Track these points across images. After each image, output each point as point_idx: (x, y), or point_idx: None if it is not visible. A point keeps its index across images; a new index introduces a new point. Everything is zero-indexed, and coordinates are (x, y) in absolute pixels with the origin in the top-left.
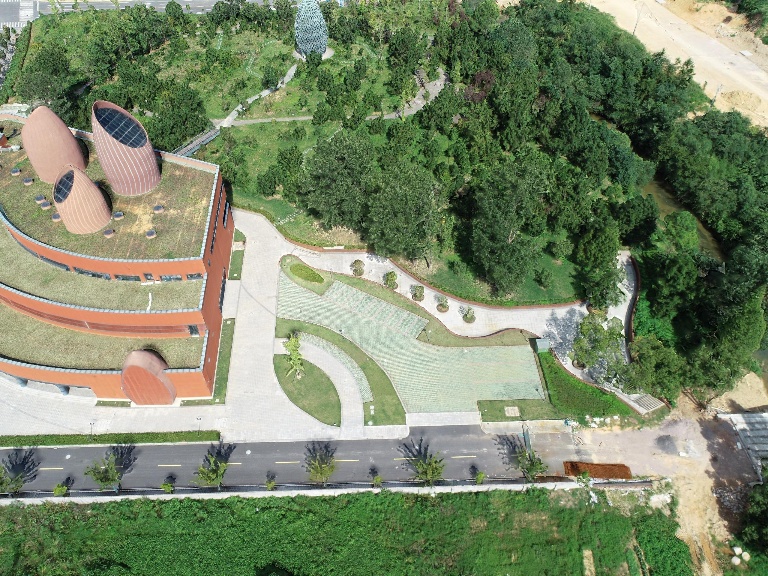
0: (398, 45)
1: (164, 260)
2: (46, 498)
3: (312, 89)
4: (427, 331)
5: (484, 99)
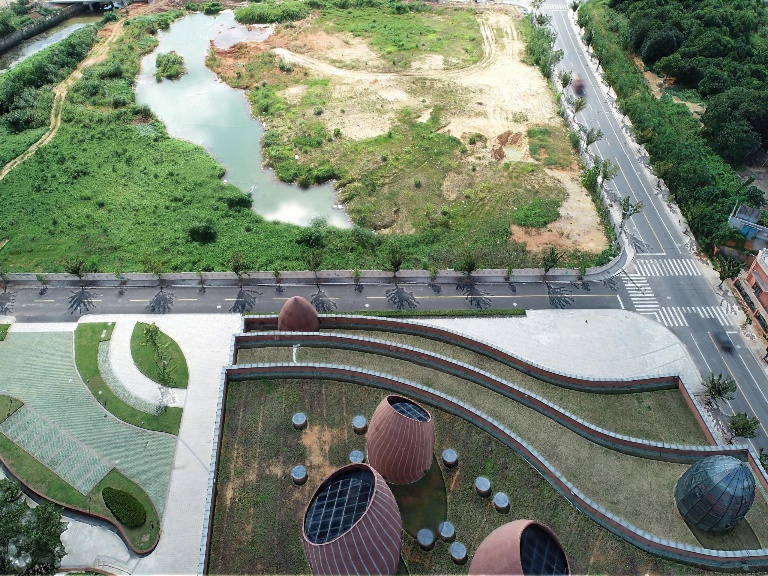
0: None
1: (269, 364)
2: (365, 270)
3: None
4: (6, 413)
5: None
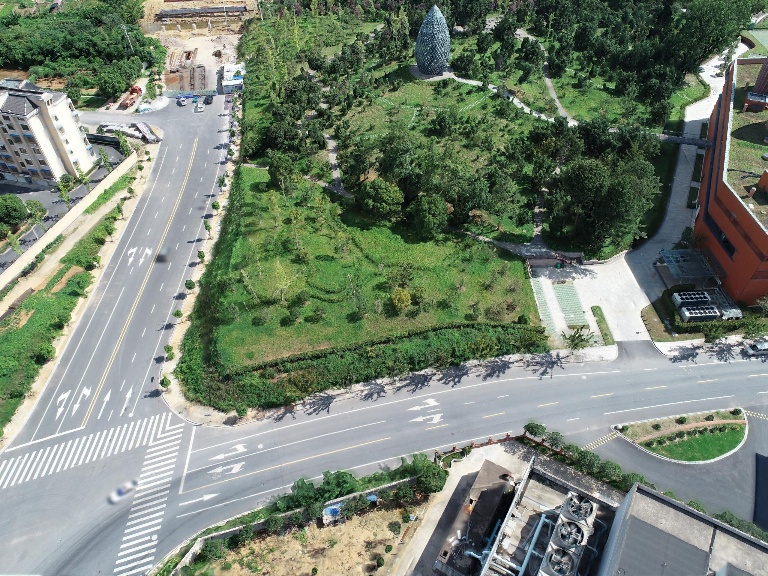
0: (477, 7)
1: None
2: None
3: (503, 75)
4: (760, 53)
5: (533, 1)
